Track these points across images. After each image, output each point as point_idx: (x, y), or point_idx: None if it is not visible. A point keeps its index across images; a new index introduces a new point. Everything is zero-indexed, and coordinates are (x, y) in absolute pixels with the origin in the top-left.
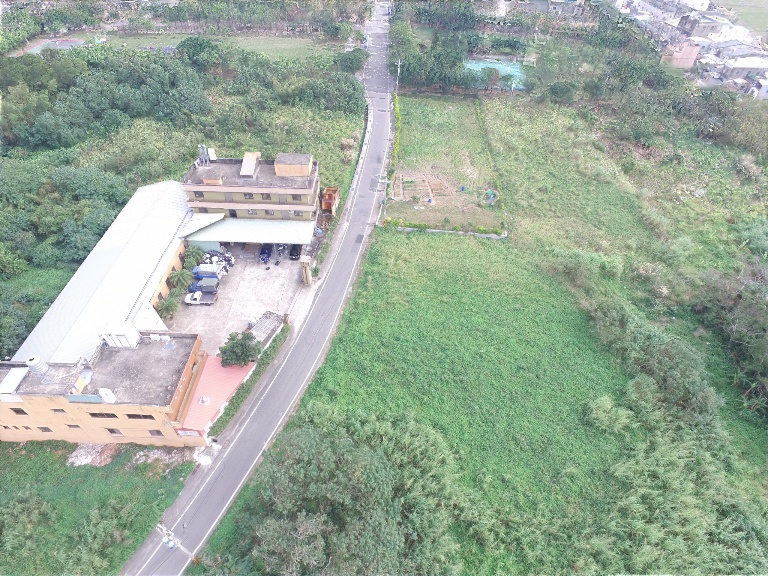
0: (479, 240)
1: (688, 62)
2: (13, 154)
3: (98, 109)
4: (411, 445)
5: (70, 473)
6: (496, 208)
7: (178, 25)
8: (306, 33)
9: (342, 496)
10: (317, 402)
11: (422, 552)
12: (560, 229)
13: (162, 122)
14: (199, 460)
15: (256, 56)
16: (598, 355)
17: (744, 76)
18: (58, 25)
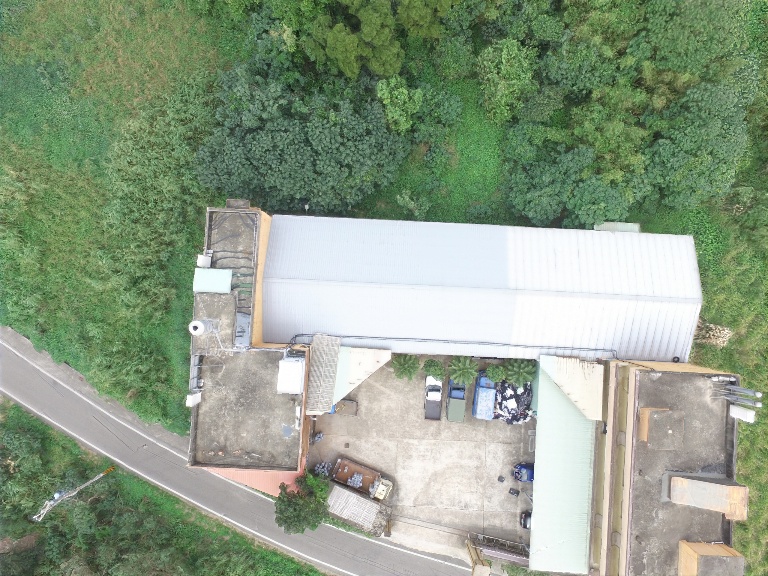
0: None
1: None
2: None
3: None
4: None
5: None
6: None
7: None
8: None
9: None
10: None
11: None
12: None
13: None
14: None
15: None
16: None
17: None
18: None
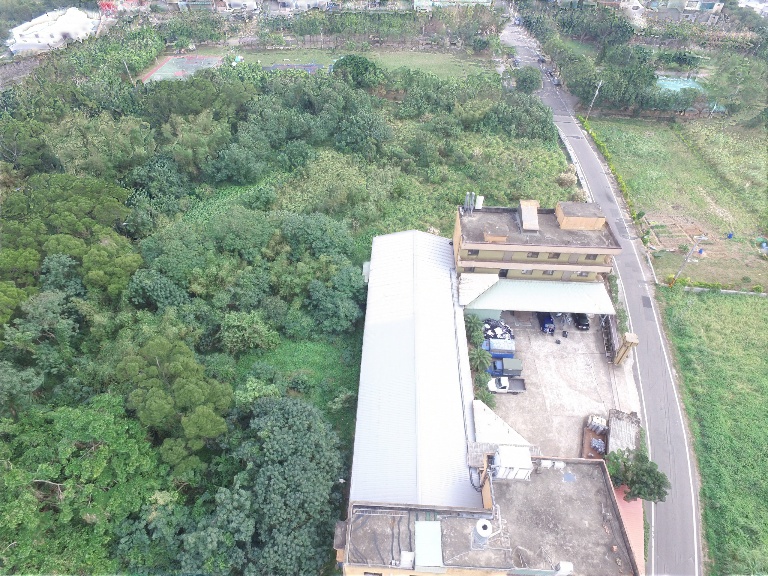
0: None
1: None
2: (201, 192)
3: (276, 138)
4: None
5: None
6: None
7: (309, 40)
8: (445, 47)
9: None
10: (754, 551)
11: None
12: None
13: (354, 154)
14: None
15: (425, 76)
16: None
17: None
18: (185, 41)
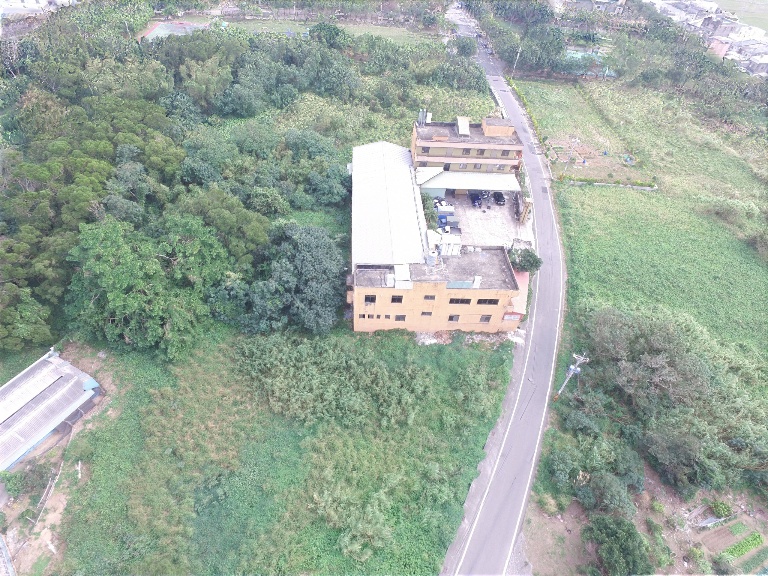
0: (638, 191)
1: (718, 58)
2: (213, 121)
3: (268, 84)
4: (677, 321)
5: (425, 349)
6: (639, 168)
7: (283, 12)
8: (400, 23)
9: (666, 344)
10: (590, 298)
11: (719, 383)
12: (697, 183)
13: (332, 96)
14: (514, 340)
15: (385, 41)
16: (766, 269)
17: (767, 71)
18: (173, 8)
